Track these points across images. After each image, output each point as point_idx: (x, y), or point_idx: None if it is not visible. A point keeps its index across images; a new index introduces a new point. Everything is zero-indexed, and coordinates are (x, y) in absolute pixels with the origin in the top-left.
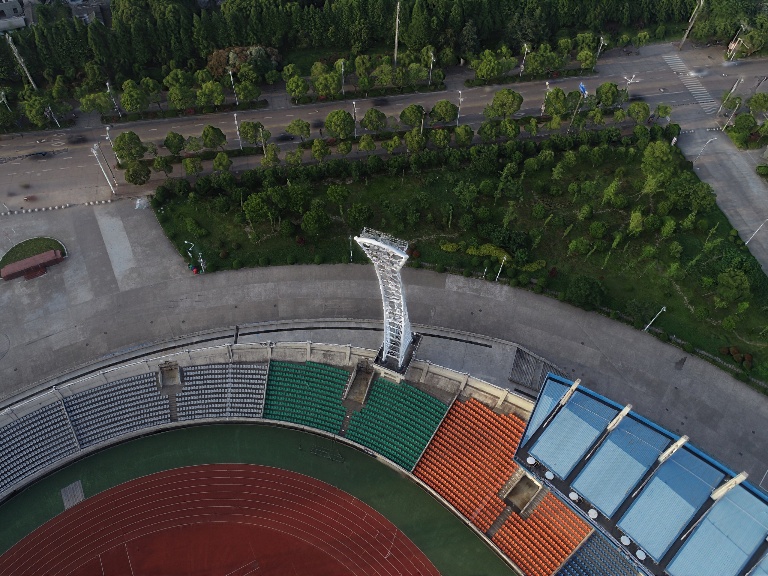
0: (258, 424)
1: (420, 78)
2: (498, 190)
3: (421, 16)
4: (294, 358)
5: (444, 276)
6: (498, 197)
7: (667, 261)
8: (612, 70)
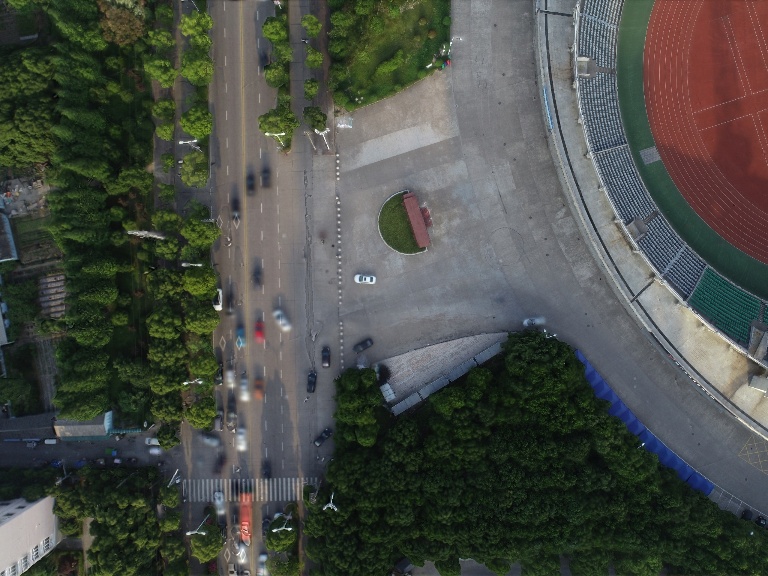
0: None
1: None
2: None
3: None
4: None
5: None
6: None
7: None
8: None
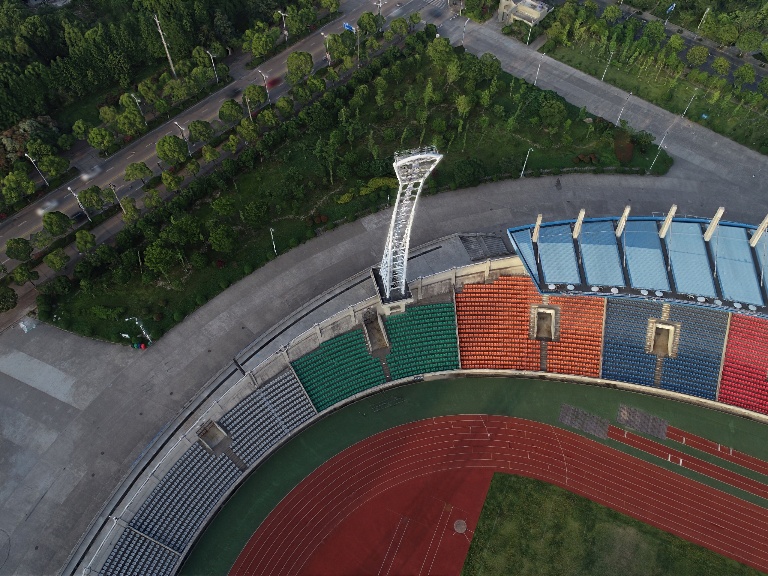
0: (313, 423)
1: (210, 78)
2: (350, 134)
3: (172, 24)
4: (308, 348)
5: (359, 222)
6: (352, 140)
7: None
8: (351, 6)
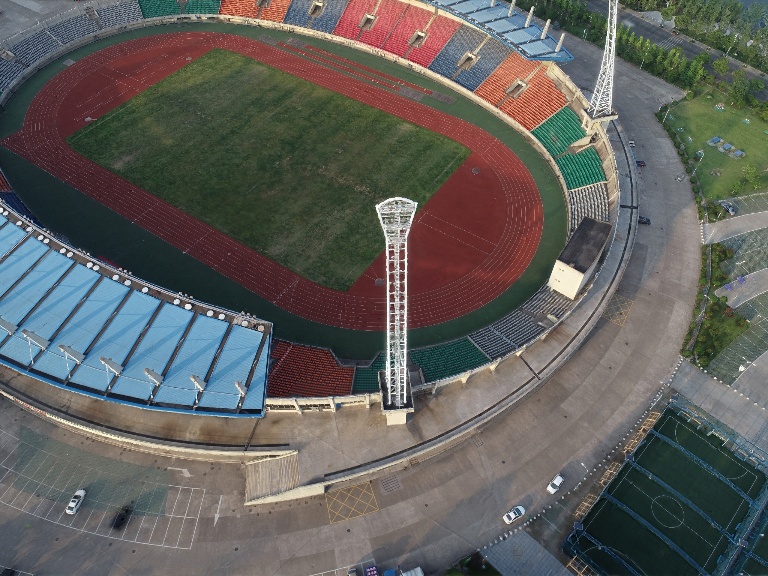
0: (143, 28)
1: None
2: None
3: None
4: None
5: None
6: None
7: None
8: None
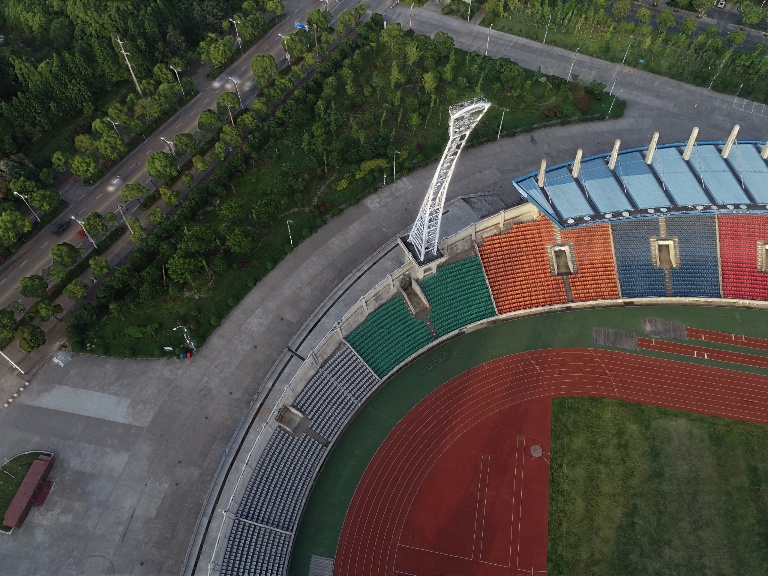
0: (376, 391)
1: (178, 93)
2: (332, 123)
3: (127, 45)
4: (357, 322)
5: (362, 204)
6: (335, 129)
7: (464, 94)
8: (292, 7)
